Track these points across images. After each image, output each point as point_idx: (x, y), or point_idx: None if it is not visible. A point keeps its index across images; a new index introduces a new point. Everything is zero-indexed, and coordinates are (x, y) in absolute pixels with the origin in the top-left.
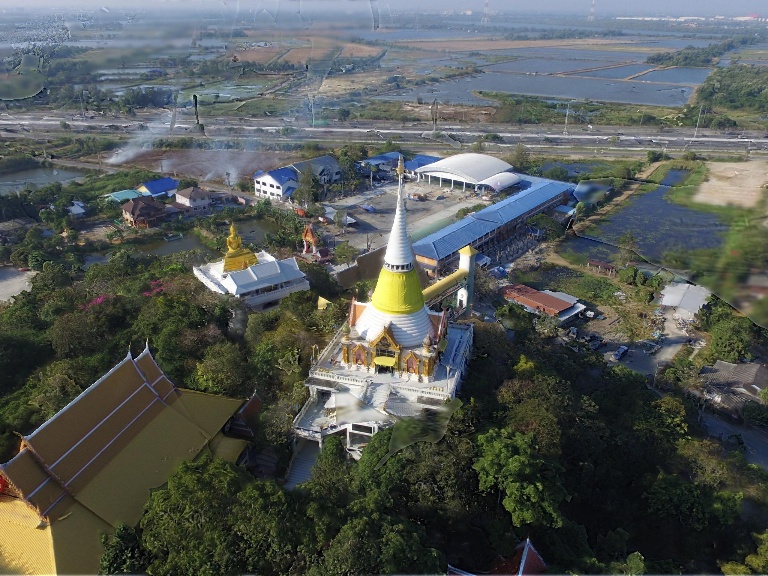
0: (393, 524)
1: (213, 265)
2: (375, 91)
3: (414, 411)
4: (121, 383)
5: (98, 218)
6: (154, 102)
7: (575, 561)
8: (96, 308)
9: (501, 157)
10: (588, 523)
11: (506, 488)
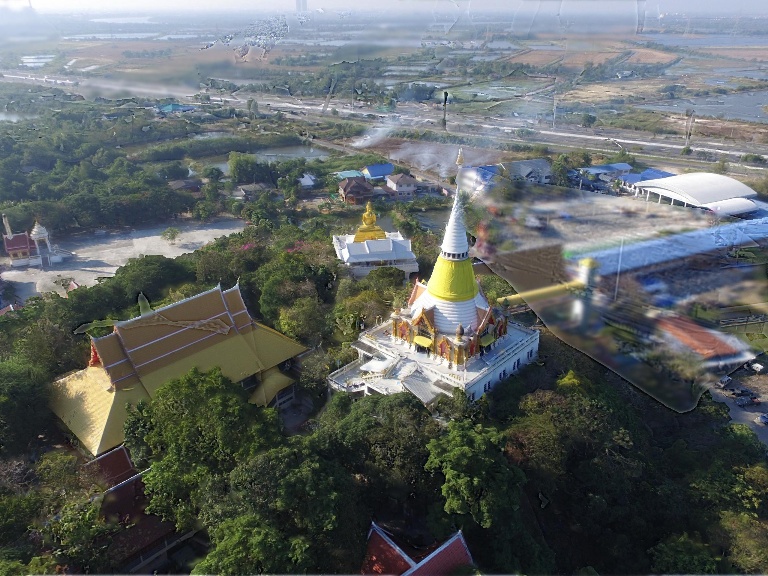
0: (321, 464)
1: (349, 236)
2: (642, 99)
3: (430, 392)
4: (206, 306)
5: (322, 191)
6: (417, 97)
7: (509, 572)
8: (242, 253)
9: (744, 181)
10: (595, 563)
11: (446, 473)
